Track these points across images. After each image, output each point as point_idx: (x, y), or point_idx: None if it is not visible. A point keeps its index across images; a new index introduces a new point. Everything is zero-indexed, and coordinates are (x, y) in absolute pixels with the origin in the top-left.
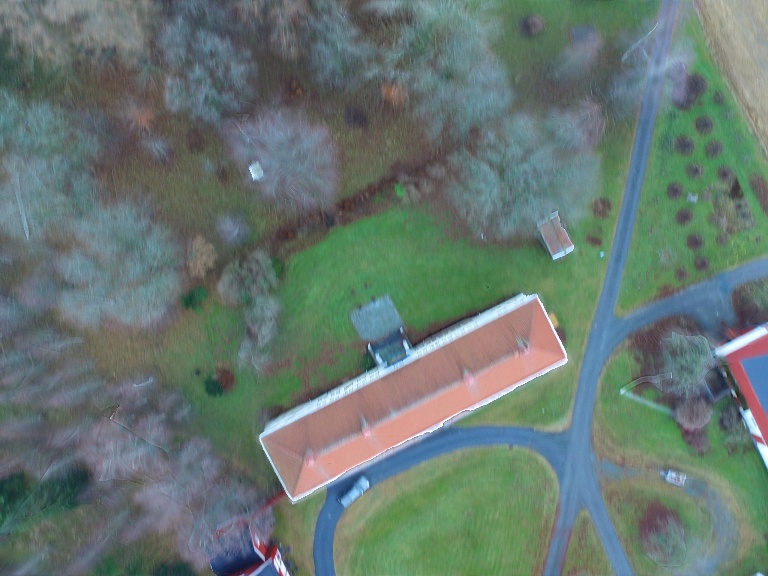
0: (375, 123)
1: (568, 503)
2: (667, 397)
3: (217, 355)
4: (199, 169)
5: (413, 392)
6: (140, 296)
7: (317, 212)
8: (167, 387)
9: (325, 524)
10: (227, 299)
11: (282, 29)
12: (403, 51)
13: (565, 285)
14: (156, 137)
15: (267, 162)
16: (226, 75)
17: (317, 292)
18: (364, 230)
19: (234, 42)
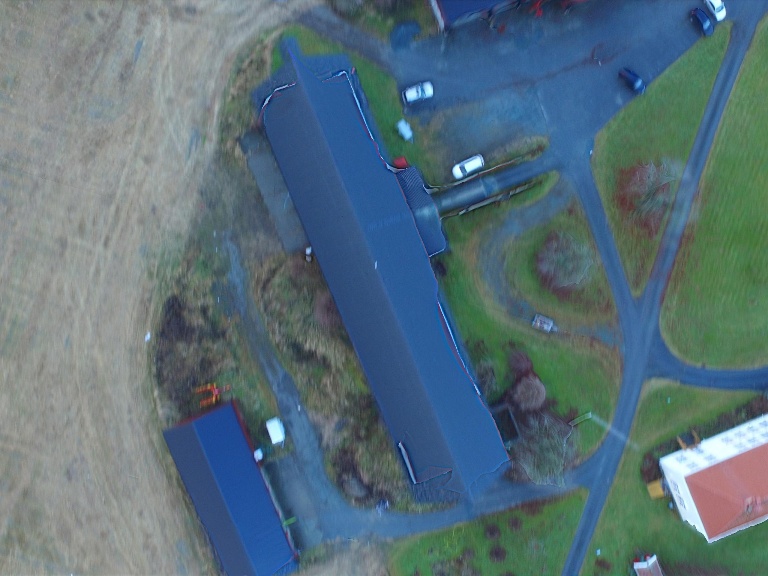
0: None
1: (652, 305)
2: (549, 408)
3: None
4: None
5: None
6: None
7: None
8: None
9: None
10: None
11: None
12: None
13: (637, 524)
14: None
15: None
16: None
17: None
18: None
19: None
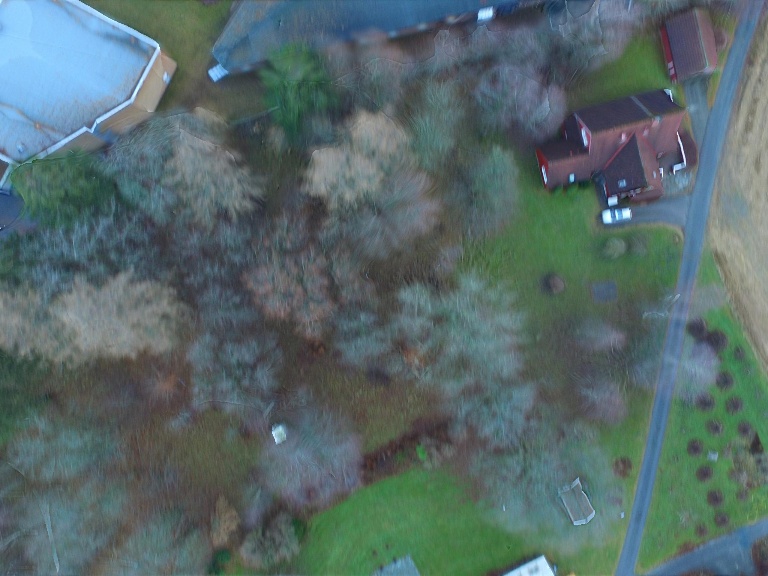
0: (397, 381)
1: None
2: None
3: None
4: (222, 427)
5: None
6: (163, 560)
7: (339, 472)
8: None
9: None
10: (250, 562)
11: (307, 322)
12: (428, 349)
13: (586, 545)
14: (180, 401)
15: (290, 426)
16: (252, 376)
17: (339, 553)
18: (386, 491)
19: (260, 345)
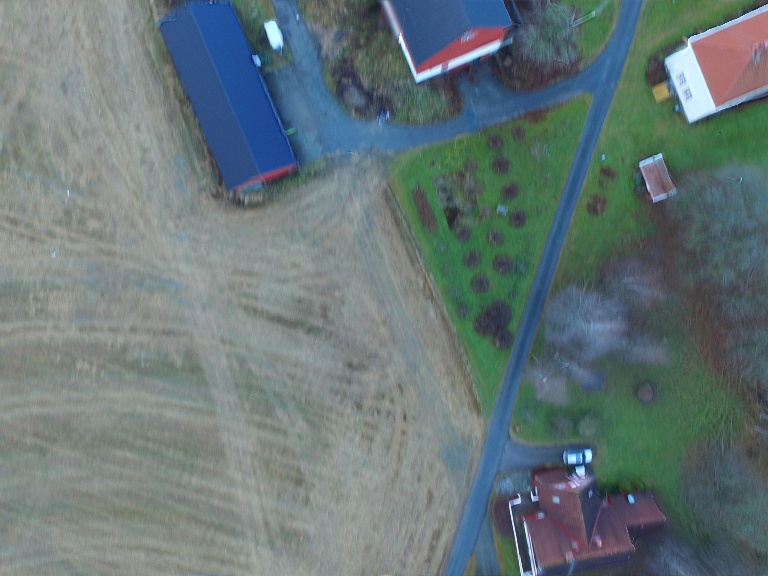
0: None
1: None
2: None
3: None
4: None
5: None
6: None
7: None
8: None
9: None
10: None
11: None
12: None
13: (642, 129)
14: None
15: None
16: None
17: None
18: None
19: None
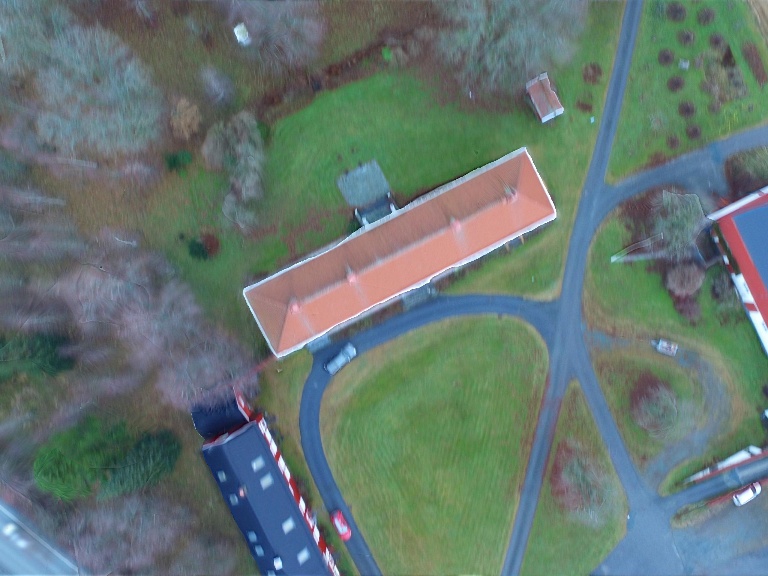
0: None
1: (558, 373)
2: (658, 264)
3: (201, 220)
4: (183, 34)
5: (399, 241)
6: (123, 159)
7: (303, 76)
8: (151, 252)
9: (311, 393)
10: (212, 163)
11: None
12: None
13: (555, 151)
14: None
15: (252, 24)
16: None
17: (303, 157)
18: (351, 95)
19: None
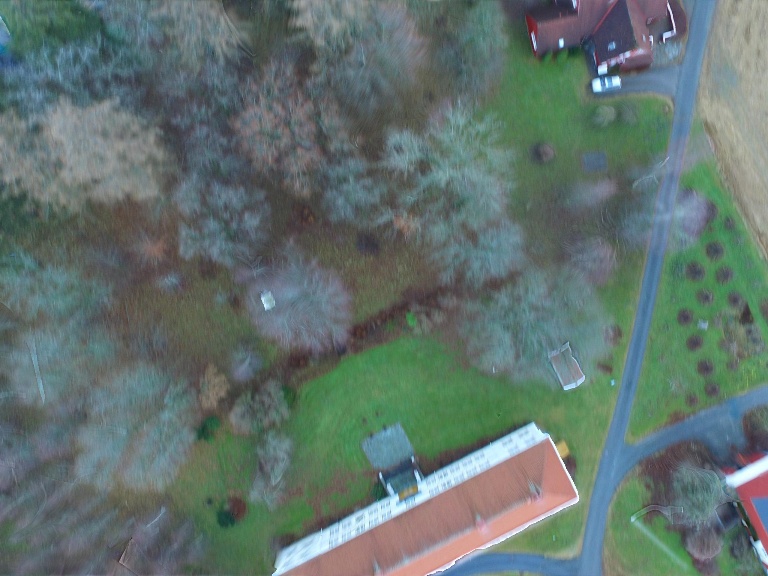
0: (386, 250)
1: None
2: (678, 525)
3: (229, 484)
4: (211, 296)
5: (425, 537)
6: (152, 426)
7: (329, 340)
8: (179, 516)
9: None
10: (239, 428)
11: (295, 173)
12: (416, 198)
13: (576, 413)
14: (169, 267)
15: (279, 292)
16: (240, 223)
17: (329, 420)
18: (375, 358)
19: (248, 191)
